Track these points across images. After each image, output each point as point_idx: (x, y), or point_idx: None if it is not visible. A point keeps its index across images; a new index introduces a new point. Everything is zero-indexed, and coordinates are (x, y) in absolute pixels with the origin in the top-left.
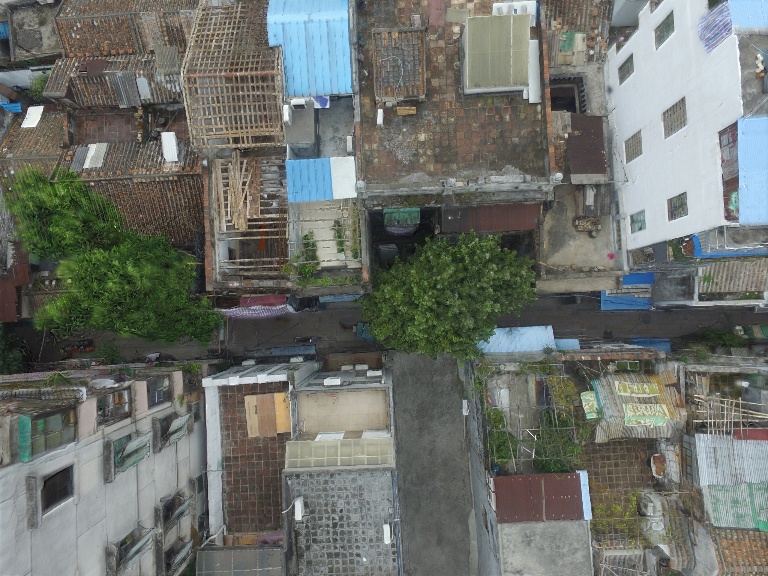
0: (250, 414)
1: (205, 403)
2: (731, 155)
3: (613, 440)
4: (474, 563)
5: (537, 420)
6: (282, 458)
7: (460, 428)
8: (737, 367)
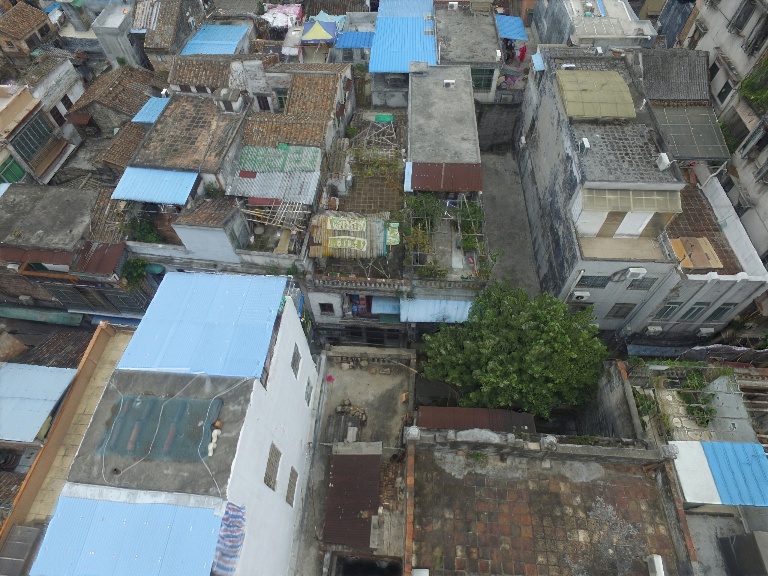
0: (712, 254)
1: None
2: (267, 355)
3: None
4: None
5: None
6: None
7: None
8: (251, 256)
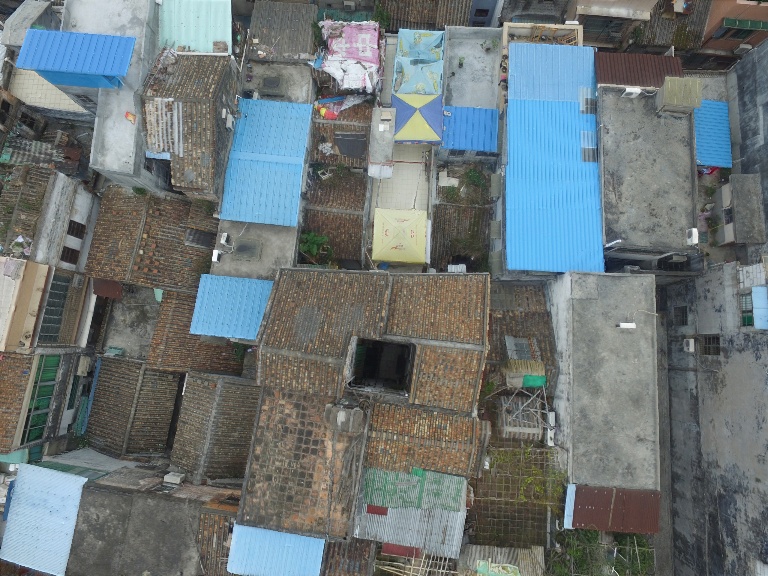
0: None
1: None
2: None
3: (500, 520)
4: None
5: None
6: None
7: None
8: None
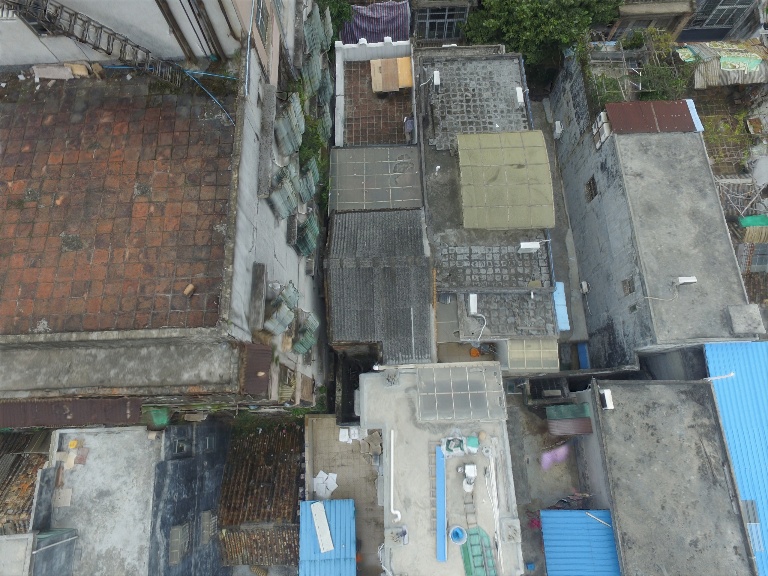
0: (375, 73)
1: (335, 63)
2: None
3: None
4: (574, 278)
5: (633, 100)
6: (400, 119)
7: (551, 161)
8: None
